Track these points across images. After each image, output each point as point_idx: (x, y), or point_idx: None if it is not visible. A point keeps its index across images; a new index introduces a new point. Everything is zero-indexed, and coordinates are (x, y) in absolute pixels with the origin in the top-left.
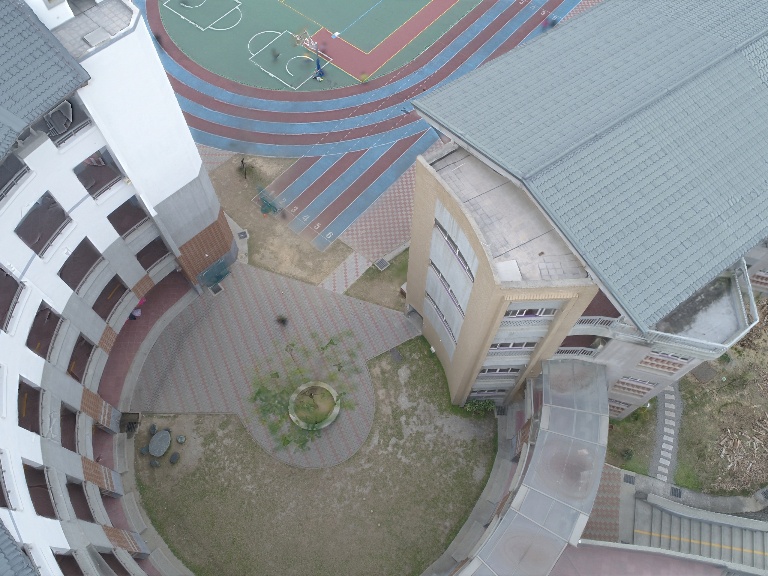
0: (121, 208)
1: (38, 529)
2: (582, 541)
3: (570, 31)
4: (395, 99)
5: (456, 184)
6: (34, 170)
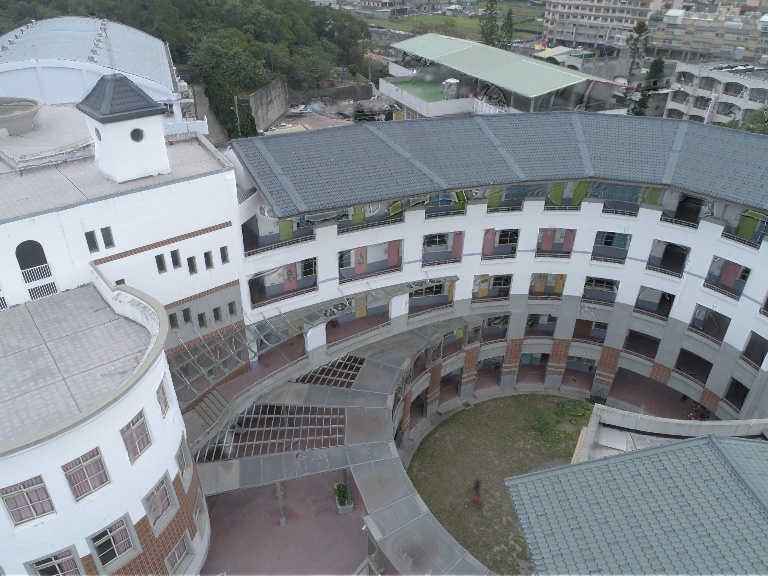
0: (762, 339)
1: (524, 270)
2: (358, 570)
3: None
4: None
5: None
6: (760, 252)
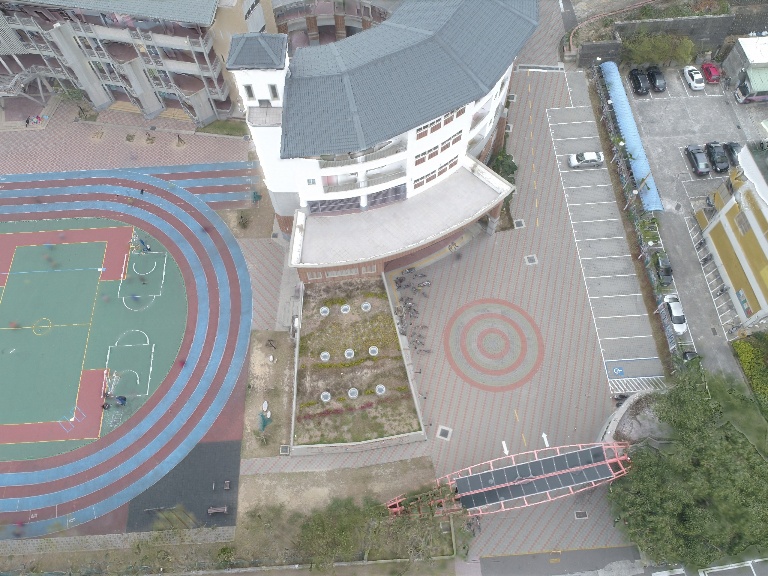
0: None
1: None
2: None
3: (131, 7)
4: (136, 203)
5: (233, 2)
6: None
